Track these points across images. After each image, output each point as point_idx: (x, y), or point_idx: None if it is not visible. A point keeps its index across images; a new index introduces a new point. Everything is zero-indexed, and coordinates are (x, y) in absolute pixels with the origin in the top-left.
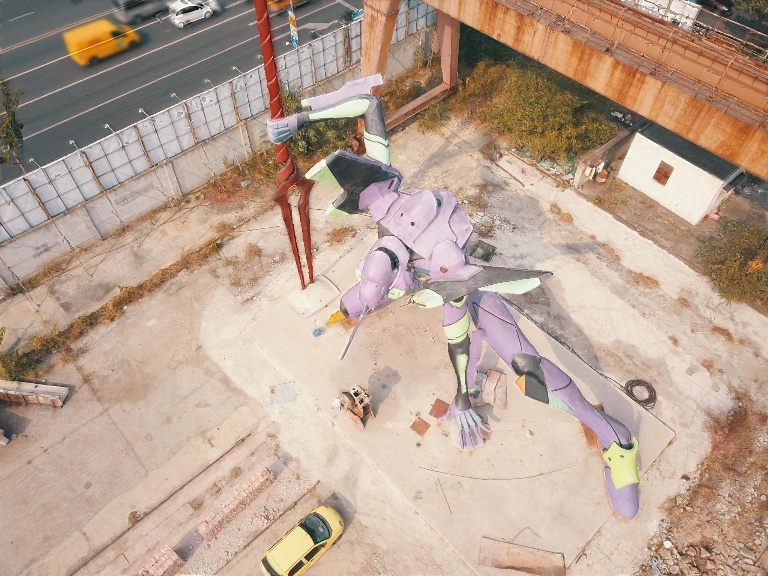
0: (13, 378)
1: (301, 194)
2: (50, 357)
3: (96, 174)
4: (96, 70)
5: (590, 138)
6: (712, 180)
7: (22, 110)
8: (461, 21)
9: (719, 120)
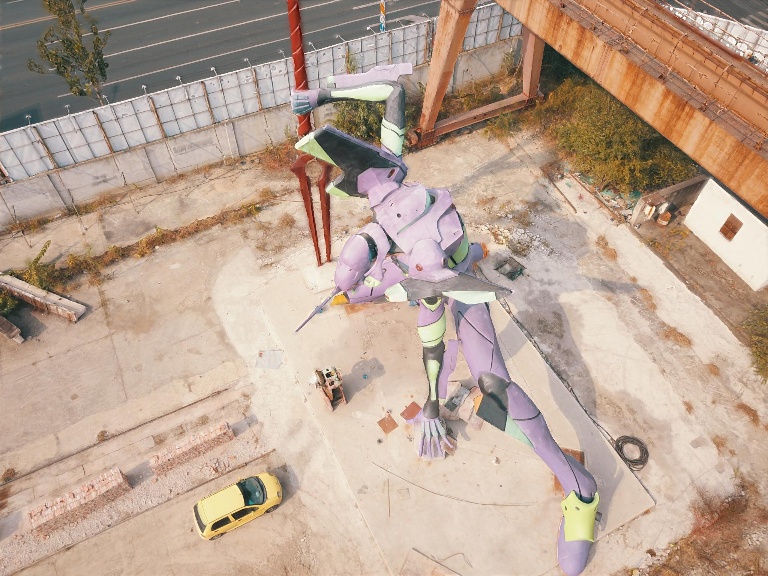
0: (43, 287)
1: None
2: (81, 276)
3: (160, 120)
4: (202, 29)
5: (660, 176)
6: None
7: (128, 55)
8: (528, 27)
9: (763, 171)
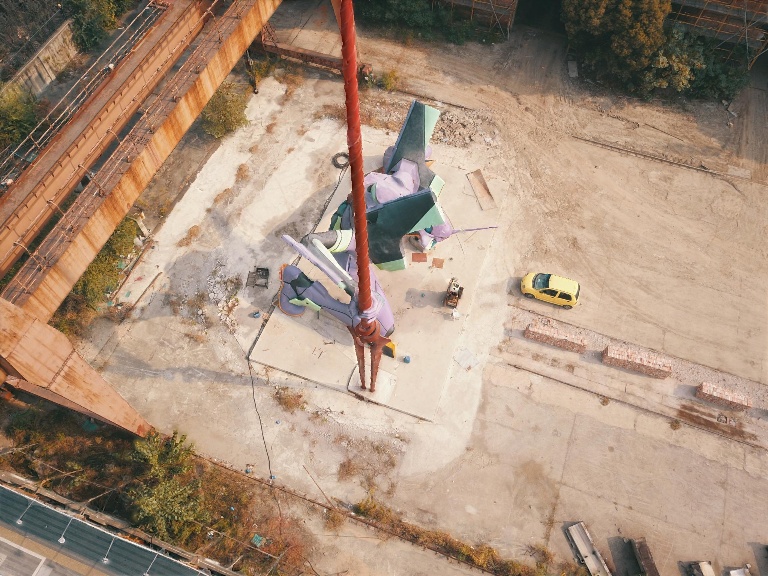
0: None
1: (358, 340)
2: None
3: None
4: None
5: None
6: None
7: None
8: None
9: None
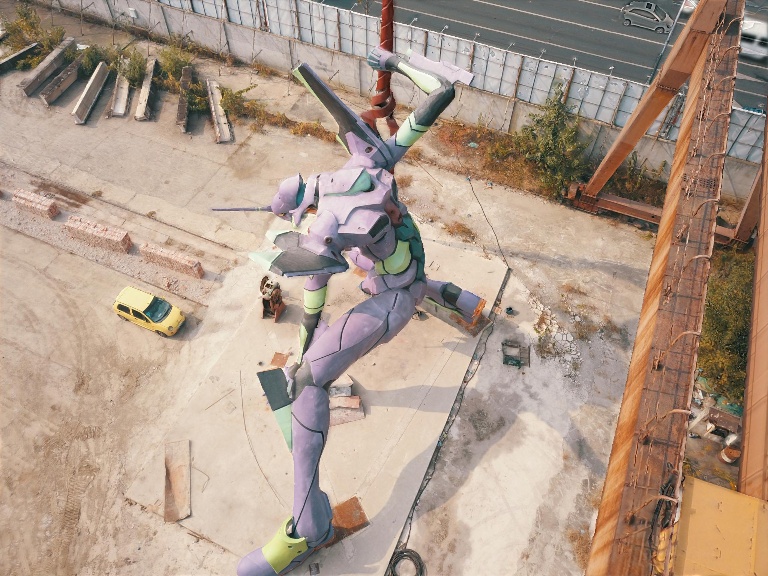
0: (225, 110)
1: None
2: (252, 120)
3: None
4: (527, 9)
5: None
6: None
7: None
8: None
9: (638, 393)
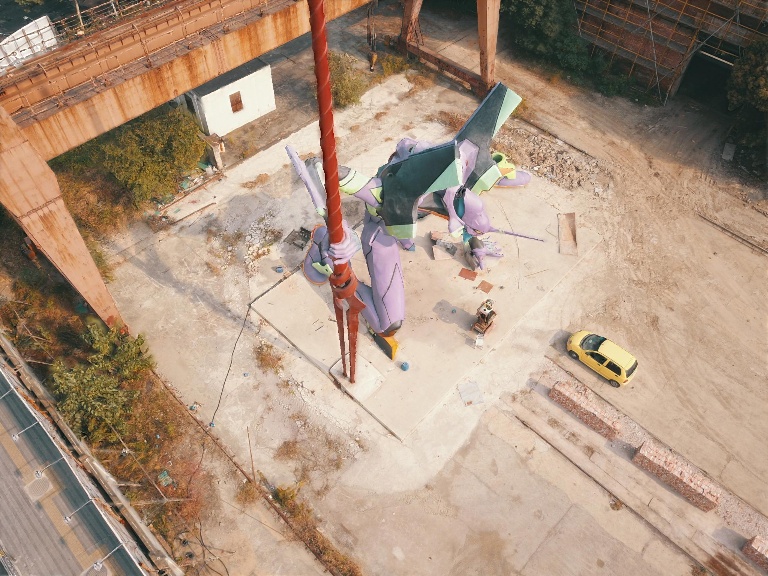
0: None
1: (336, 299)
2: None
3: None
4: None
5: None
6: (265, 71)
7: None
8: None
9: None
